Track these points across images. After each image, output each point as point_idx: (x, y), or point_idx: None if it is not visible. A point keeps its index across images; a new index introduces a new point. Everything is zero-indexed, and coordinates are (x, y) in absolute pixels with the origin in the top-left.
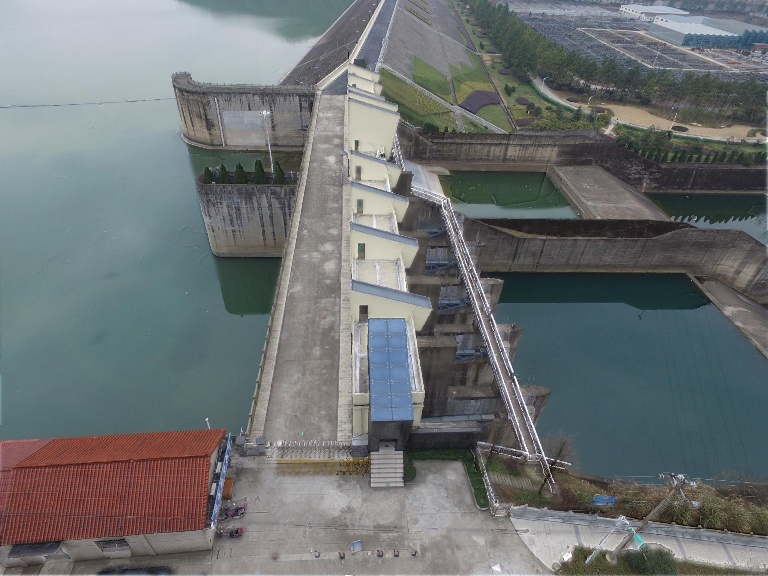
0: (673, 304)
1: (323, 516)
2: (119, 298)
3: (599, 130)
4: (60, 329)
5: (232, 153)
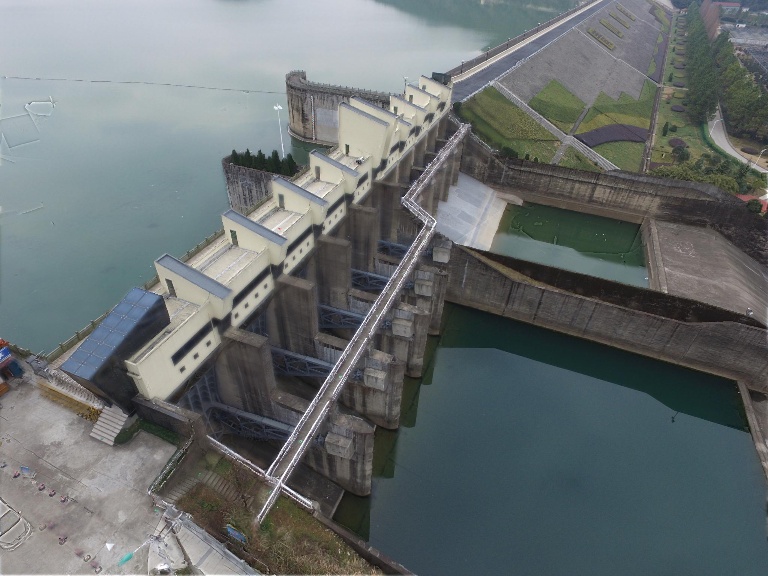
0: (720, 417)
1: (36, 440)
2: (145, 244)
3: (757, 191)
4: (92, 256)
5: (318, 147)
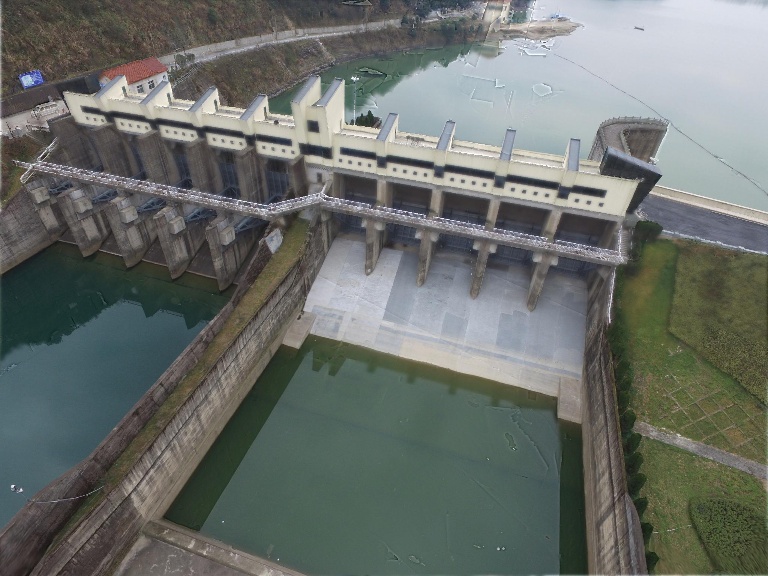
0: None
1: None
2: None
3: None
4: None
5: None
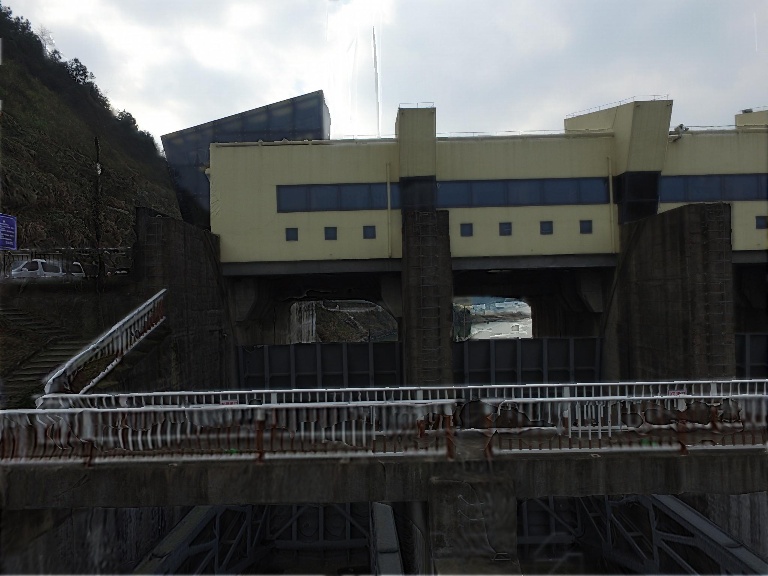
0: None
1: None
2: None
3: None
4: None
5: None
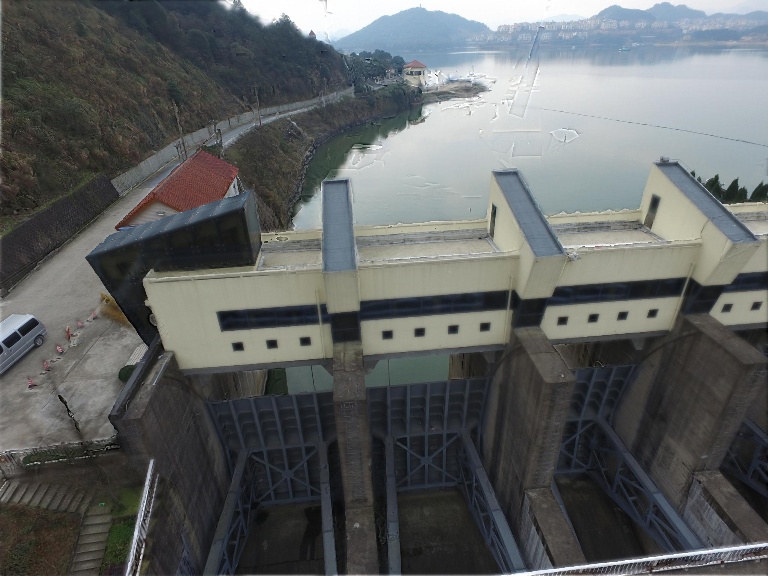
0: None
1: None
2: None
3: None
4: None
5: None
